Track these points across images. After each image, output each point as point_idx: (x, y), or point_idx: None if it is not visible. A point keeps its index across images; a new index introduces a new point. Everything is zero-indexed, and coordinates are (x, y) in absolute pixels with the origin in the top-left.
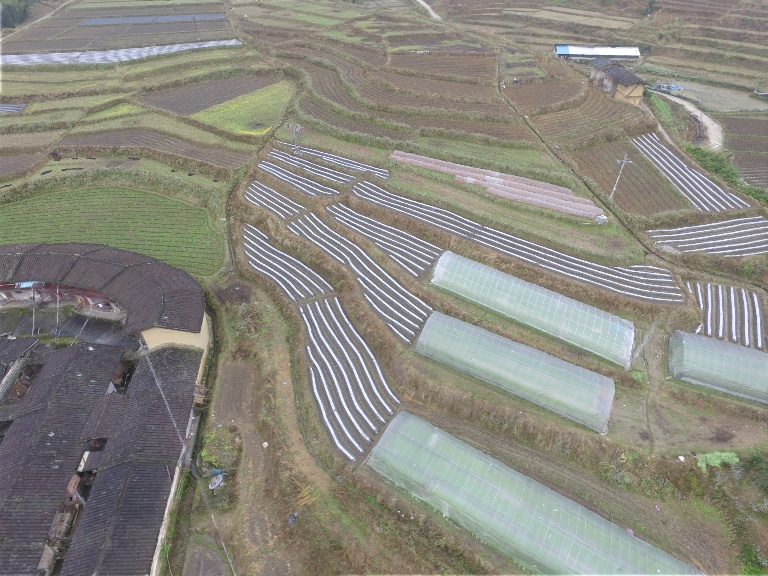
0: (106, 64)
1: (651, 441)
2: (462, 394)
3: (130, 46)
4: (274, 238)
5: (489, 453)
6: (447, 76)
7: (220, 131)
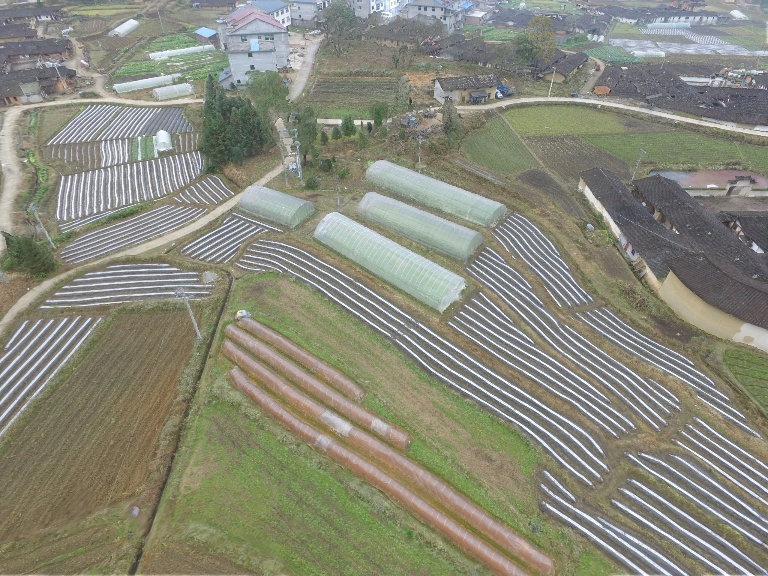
0: None
1: (353, 197)
2: None
3: None
4: None
5: (438, 212)
6: None
7: None
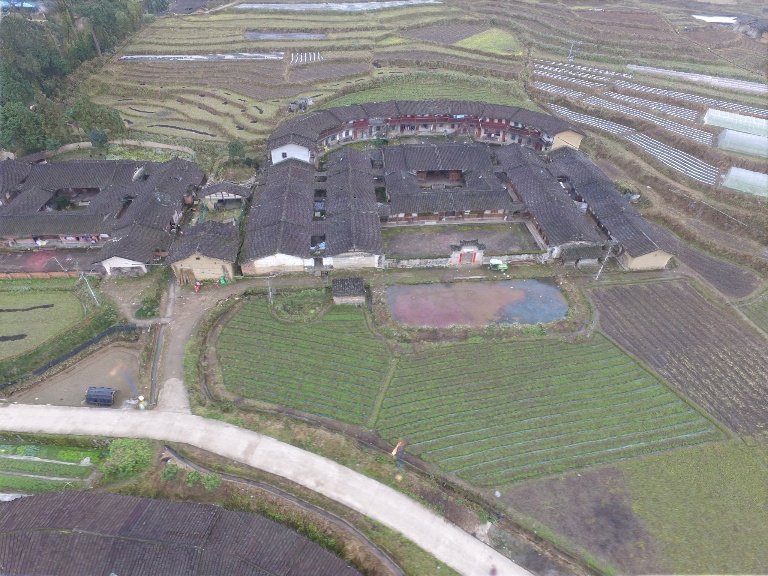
0: (357, 11)
1: None
2: (760, 161)
3: (359, 1)
4: (579, 107)
5: None
6: (633, 24)
7: (487, 53)
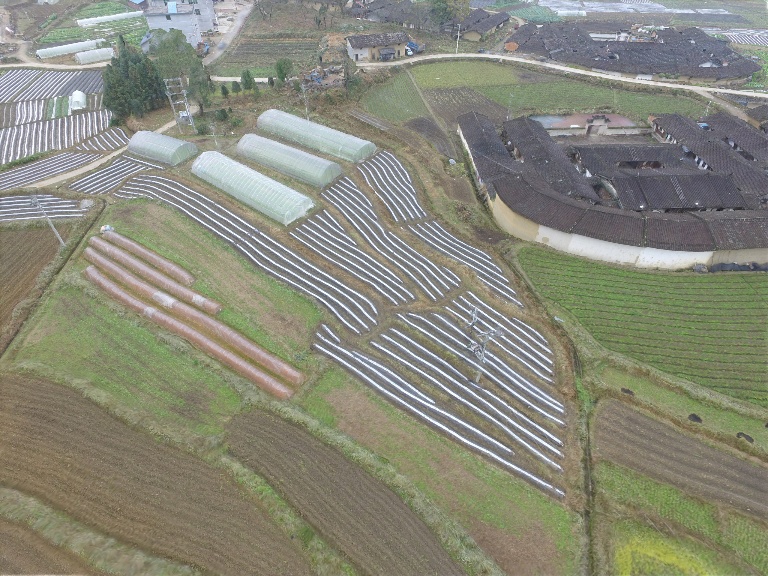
0: None
1: (238, 140)
2: None
3: None
4: None
5: (316, 152)
6: None
7: None
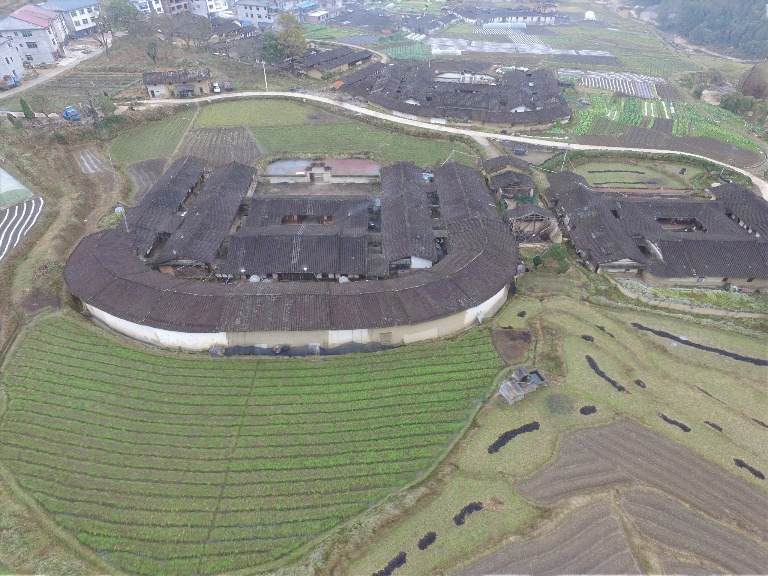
0: None
1: None
2: None
3: None
4: None
5: None
6: None
7: None
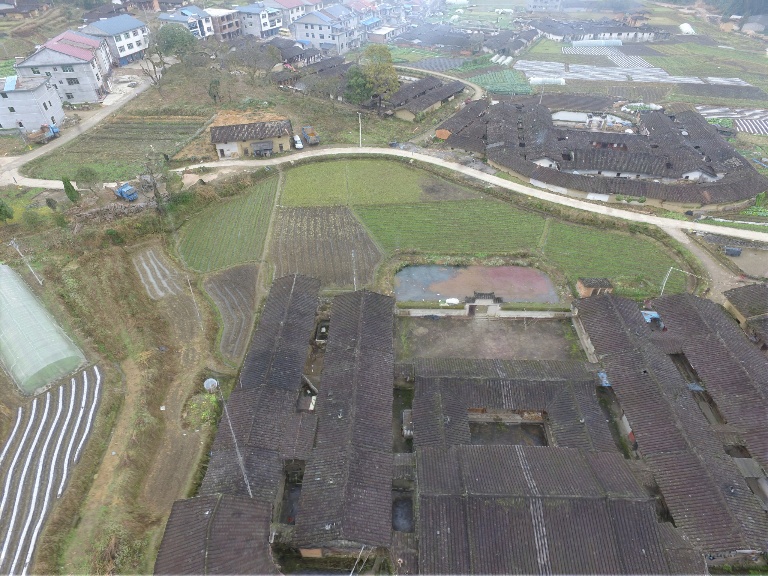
0: None
1: None
2: None
3: None
4: None
5: None
6: None
7: None
